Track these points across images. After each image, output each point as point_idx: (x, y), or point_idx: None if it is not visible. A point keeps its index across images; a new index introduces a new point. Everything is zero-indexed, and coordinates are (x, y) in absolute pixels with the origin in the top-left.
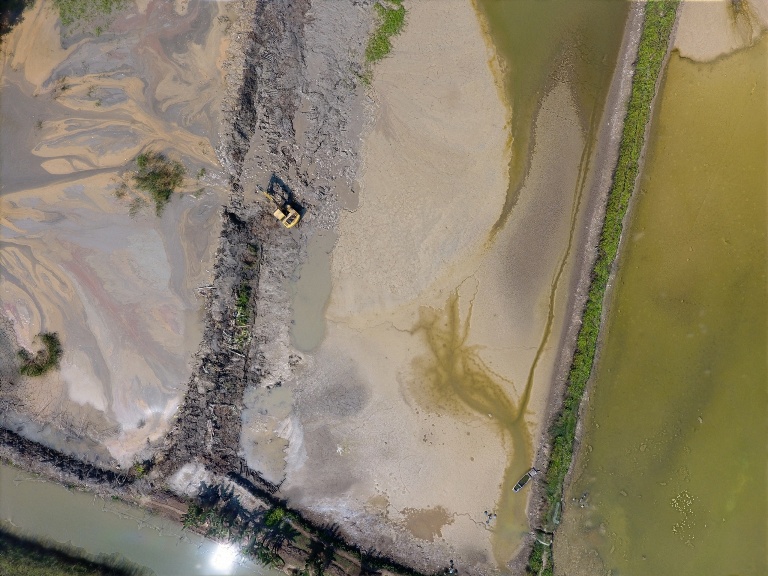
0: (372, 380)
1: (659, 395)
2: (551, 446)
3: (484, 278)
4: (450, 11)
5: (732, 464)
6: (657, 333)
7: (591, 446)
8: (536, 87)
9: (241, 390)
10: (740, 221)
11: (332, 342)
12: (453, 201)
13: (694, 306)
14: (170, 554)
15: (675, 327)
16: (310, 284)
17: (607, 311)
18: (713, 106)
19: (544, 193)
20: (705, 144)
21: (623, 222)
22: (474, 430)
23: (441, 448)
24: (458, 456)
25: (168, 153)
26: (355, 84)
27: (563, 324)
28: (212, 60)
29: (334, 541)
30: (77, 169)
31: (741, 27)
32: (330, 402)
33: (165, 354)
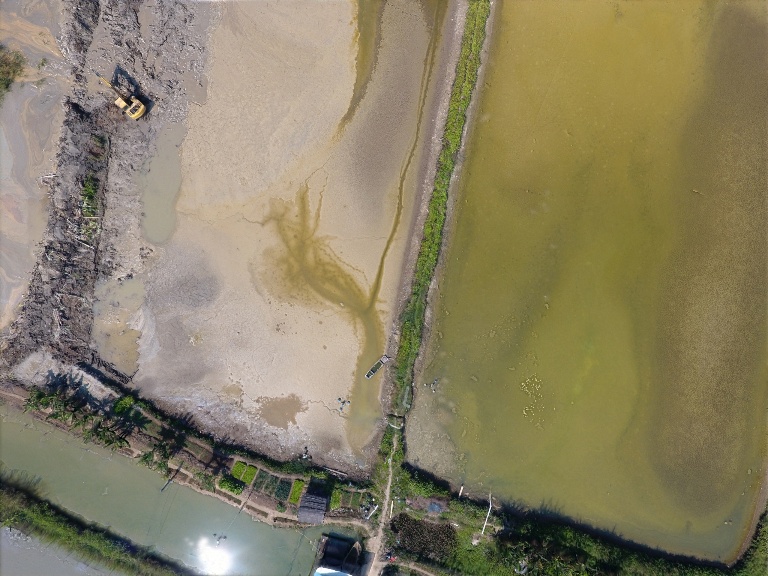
0: (224, 271)
1: (507, 283)
2: (401, 332)
3: (333, 170)
4: None
5: (579, 348)
6: (504, 222)
7: (441, 333)
8: None
9: (92, 282)
10: (581, 114)
11: (183, 234)
12: (301, 95)
13: (539, 196)
14: (23, 447)
15: (521, 216)
16: (160, 177)
17: (454, 201)
18: (553, 3)
19: (391, 87)
20: (546, 39)
21: (468, 114)
22: (326, 319)
23: (294, 337)
24: (311, 345)
25: (8, 43)
26: None
27: (412, 214)
28: None
29: (186, 429)
30: None
31: None
32: (182, 293)
33: (8, 243)
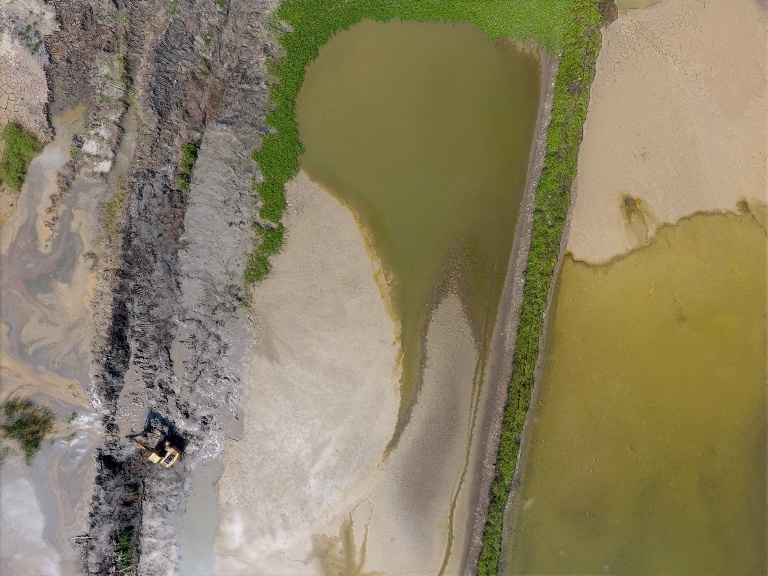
0: None
1: None
2: None
3: (379, 501)
4: (331, 226)
5: None
6: (563, 549)
7: None
8: (425, 299)
9: None
10: (644, 427)
11: None
12: (343, 423)
13: (600, 518)
14: None
15: (581, 541)
16: (196, 517)
17: (509, 529)
18: (610, 310)
19: (438, 409)
20: (604, 349)
21: (521, 436)
22: None
23: None
24: None
25: (36, 398)
26: (235, 306)
27: (464, 545)
28: (79, 299)
29: None
30: None
31: (636, 227)
32: None
33: None
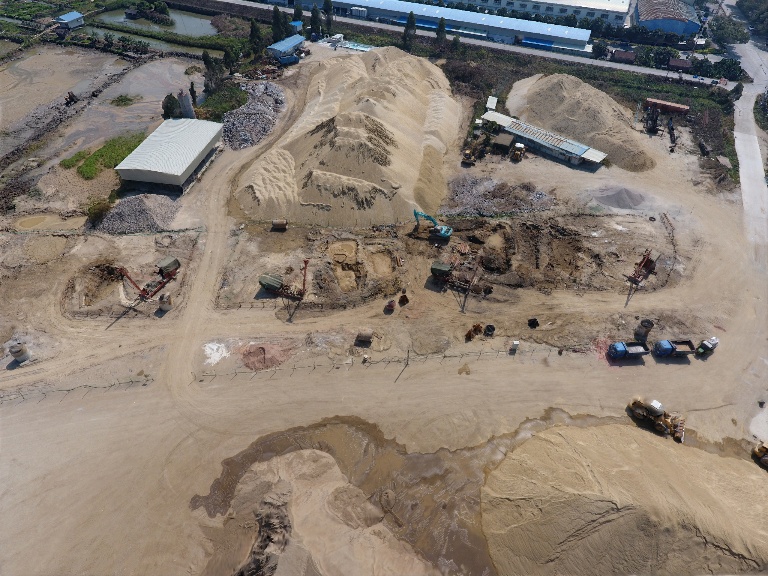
0: None
1: None
2: None
3: None
4: None
5: None
6: None
7: None
8: None
9: None
10: None
11: None
12: None
13: None
14: None
15: None
16: None
17: None
18: None
19: None
20: None
21: None
22: None
23: None
24: None
25: None
26: None
27: None
28: None
29: (103, 49)
30: (157, 102)
31: None
32: None
33: None
